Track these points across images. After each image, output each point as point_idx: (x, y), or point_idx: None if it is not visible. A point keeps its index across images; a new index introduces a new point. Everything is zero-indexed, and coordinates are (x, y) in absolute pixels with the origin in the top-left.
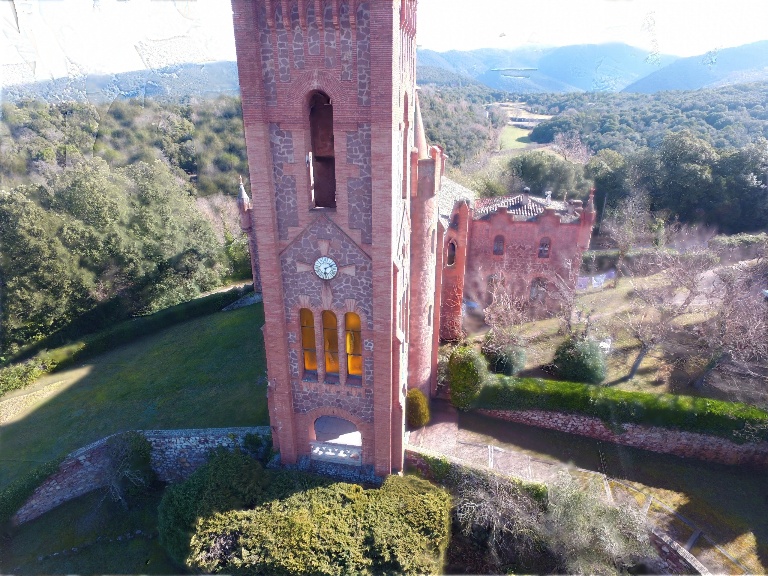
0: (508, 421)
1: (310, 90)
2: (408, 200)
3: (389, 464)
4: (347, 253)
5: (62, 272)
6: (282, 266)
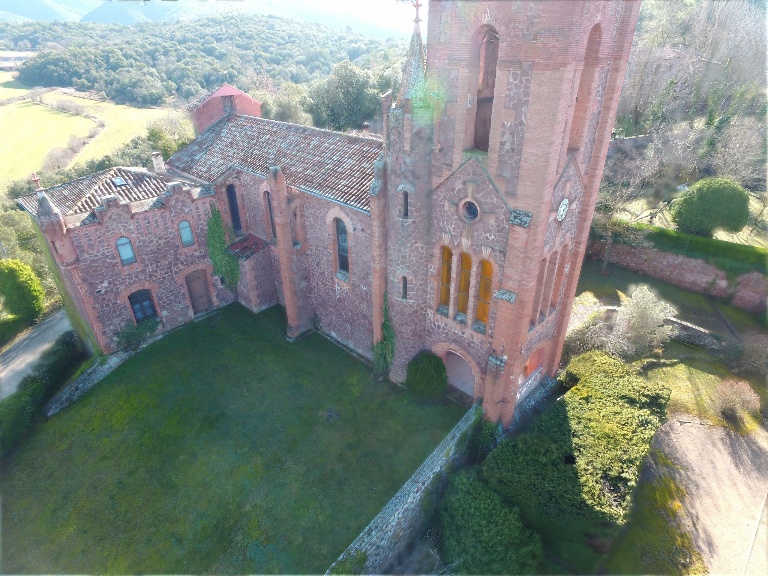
0: None
1: None
2: None
3: None
4: None
5: None
6: None
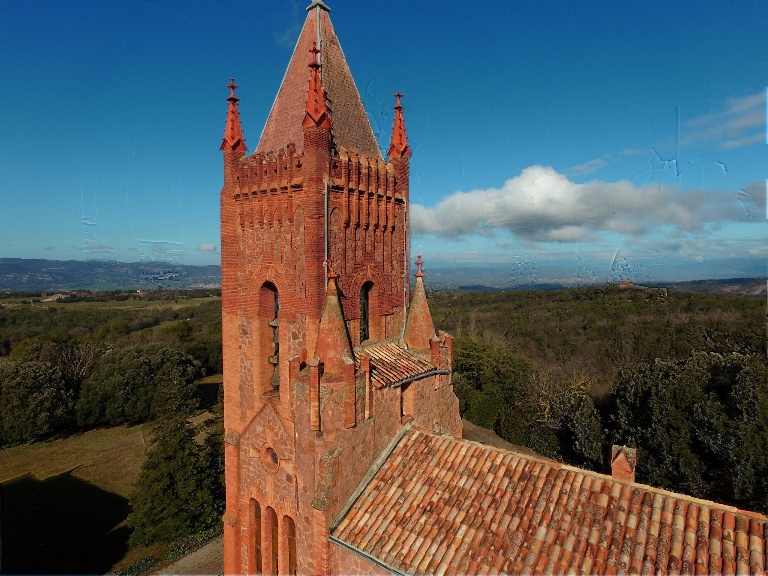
0: None
1: None
2: None
3: None
4: None
5: (662, 442)
6: None
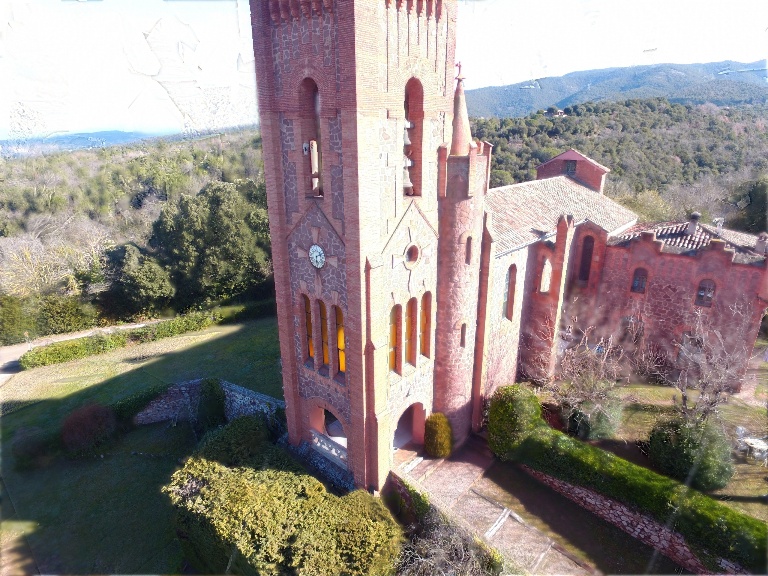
0: (555, 492)
1: (303, 79)
2: (430, 199)
3: (364, 478)
4: (332, 243)
5: (242, 248)
6: (289, 250)
